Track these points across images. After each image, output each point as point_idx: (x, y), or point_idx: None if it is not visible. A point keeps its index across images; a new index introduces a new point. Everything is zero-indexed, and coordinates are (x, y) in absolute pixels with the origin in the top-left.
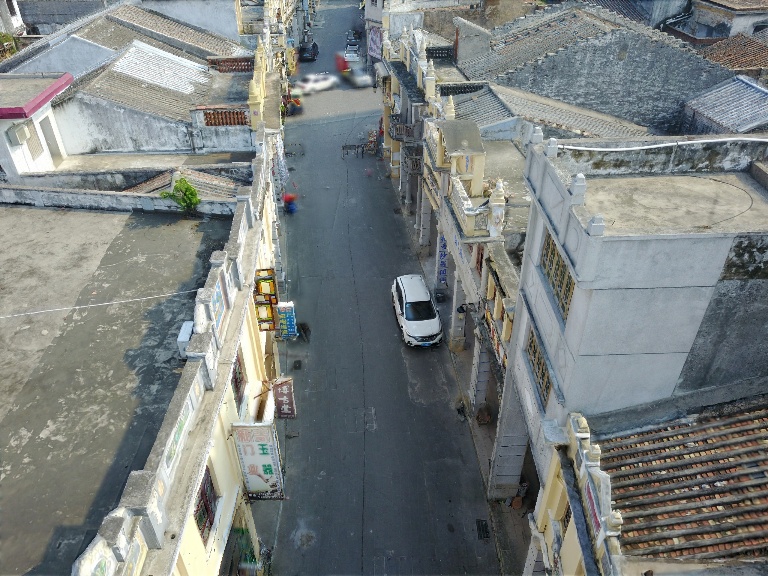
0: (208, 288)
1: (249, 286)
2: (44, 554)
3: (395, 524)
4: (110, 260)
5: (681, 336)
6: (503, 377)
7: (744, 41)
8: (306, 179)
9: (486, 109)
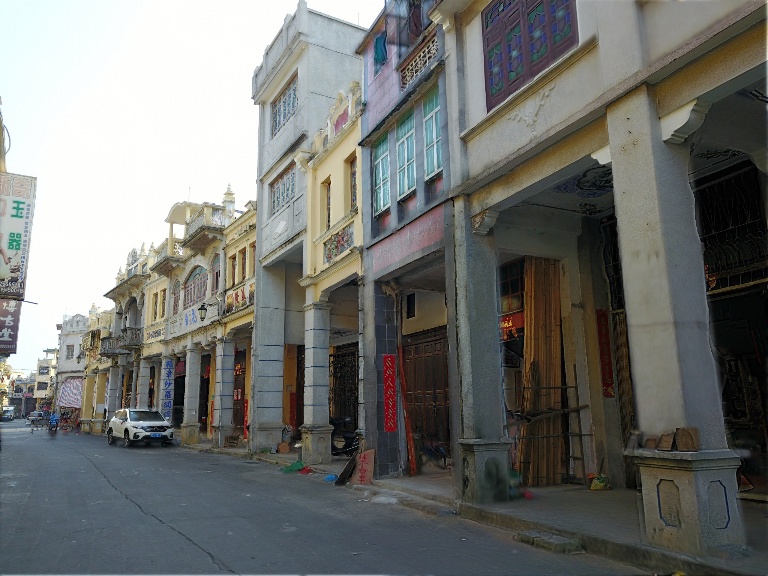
0: None
1: None
2: None
3: None
4: None
5: None
6: None
7: None
8: None
9: None
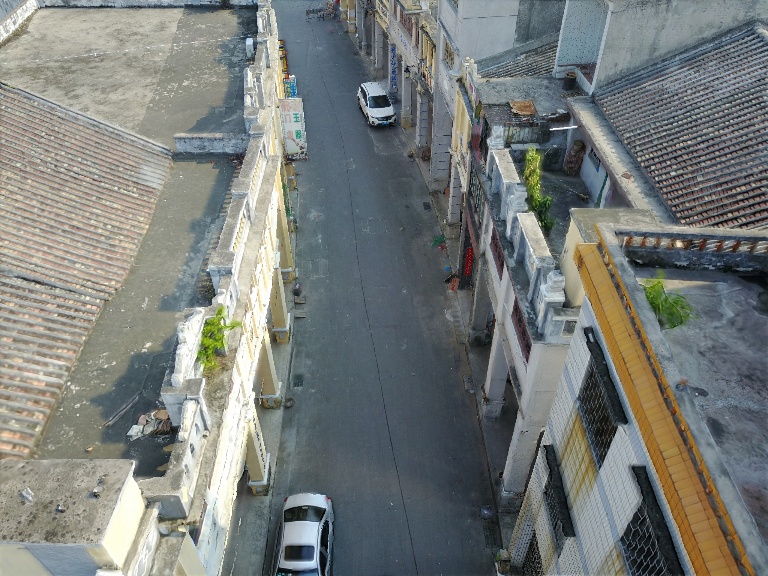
0: (262, 11)
1: (276, 34)
2: (208, 113)
3: (372, 207)
4: (183, 27)
5: (512, 4)
6: None
7: None
8: (280, 36)
9: None
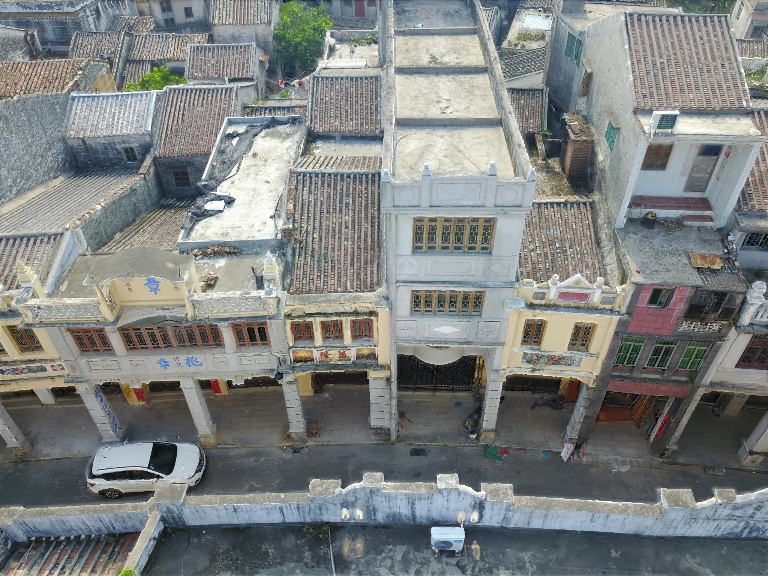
0: (439, 478)
1: None
2: None
3: None
4: None
5: None
6: (366, 363)
7: (4, 67)
8: None
9: (7, 254)
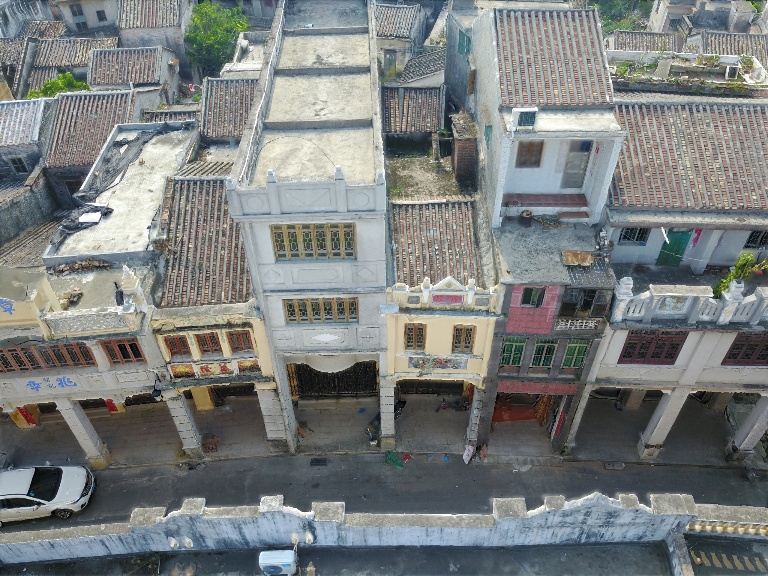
0: (262, 501)
1: None
2: None
3: None
4: None
5: None
6: (251, 375)
7: None
8: None
9: None
